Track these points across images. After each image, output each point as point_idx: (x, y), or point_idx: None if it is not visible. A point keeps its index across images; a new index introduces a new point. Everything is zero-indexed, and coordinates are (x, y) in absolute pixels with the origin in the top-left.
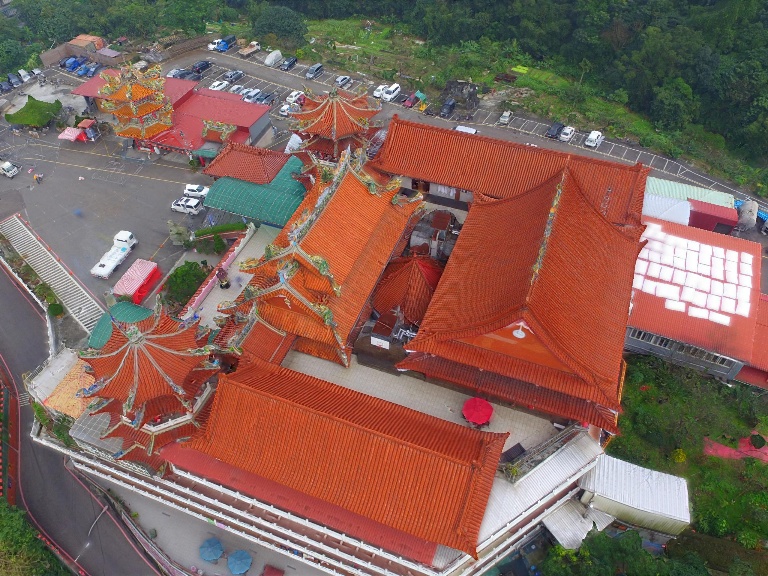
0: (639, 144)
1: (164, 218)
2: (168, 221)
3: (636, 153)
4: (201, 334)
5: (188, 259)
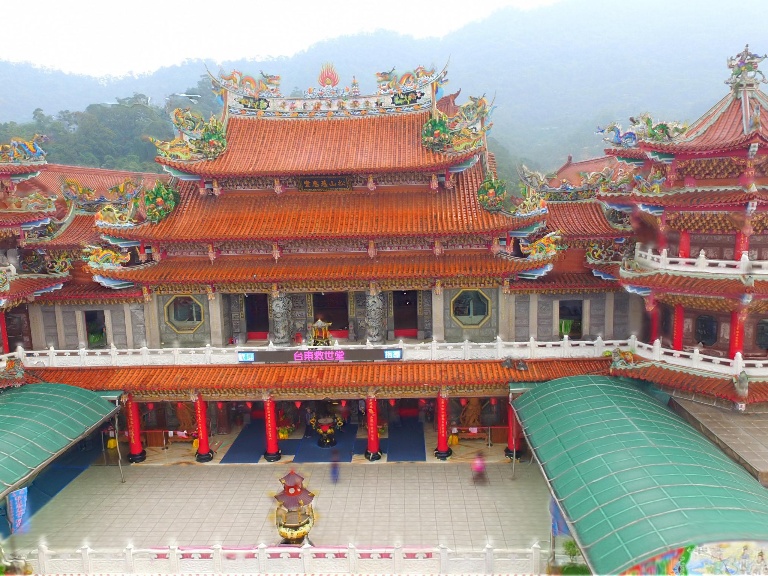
0: None
1: None
2: None
3: None
4: (620, 189)
5: None
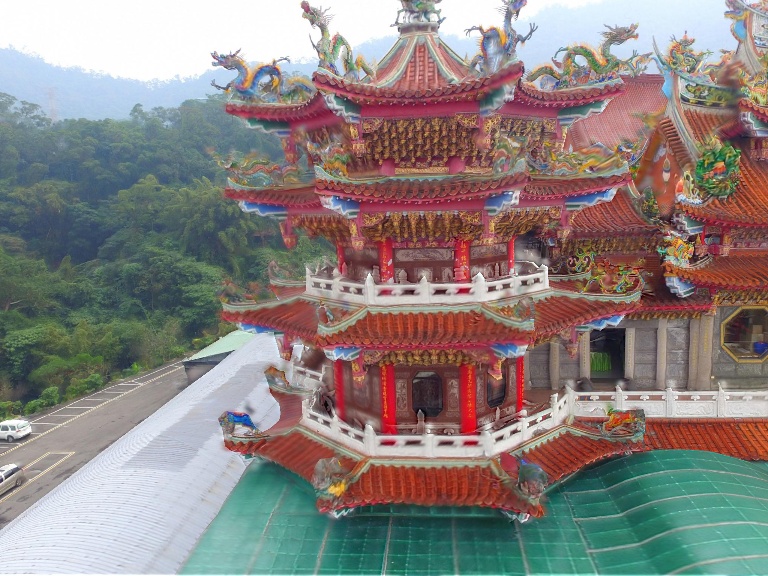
0: (45, 407)
1: None
2: None
3: (69, 409)
4: None
5: None
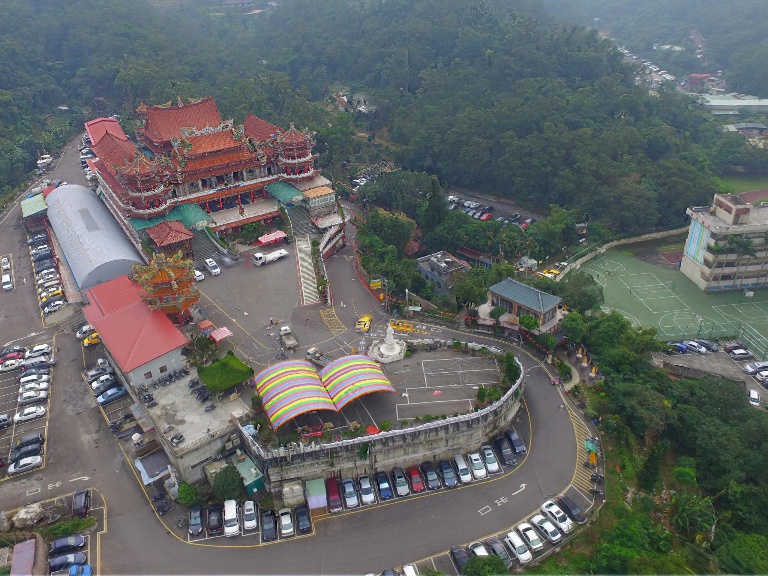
0: None
1: (229, 272)
2: (235, 242)
3: None
4: (275, 146)
5: (242, 249)
